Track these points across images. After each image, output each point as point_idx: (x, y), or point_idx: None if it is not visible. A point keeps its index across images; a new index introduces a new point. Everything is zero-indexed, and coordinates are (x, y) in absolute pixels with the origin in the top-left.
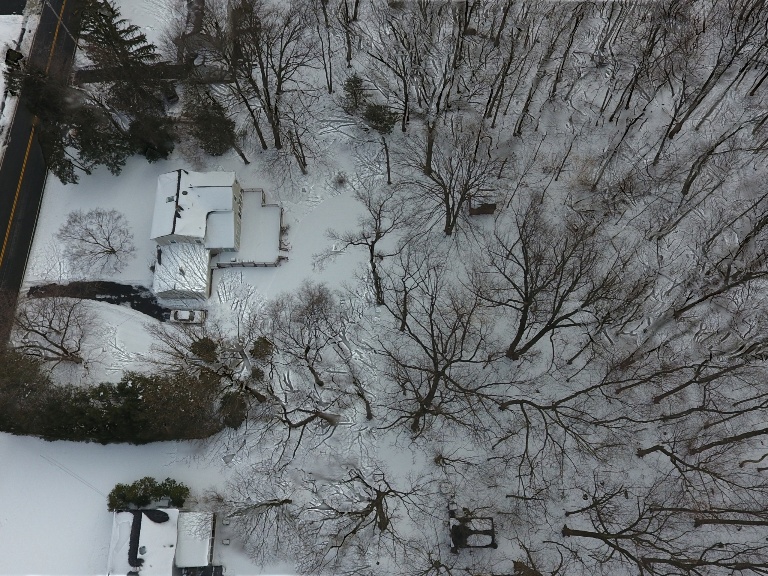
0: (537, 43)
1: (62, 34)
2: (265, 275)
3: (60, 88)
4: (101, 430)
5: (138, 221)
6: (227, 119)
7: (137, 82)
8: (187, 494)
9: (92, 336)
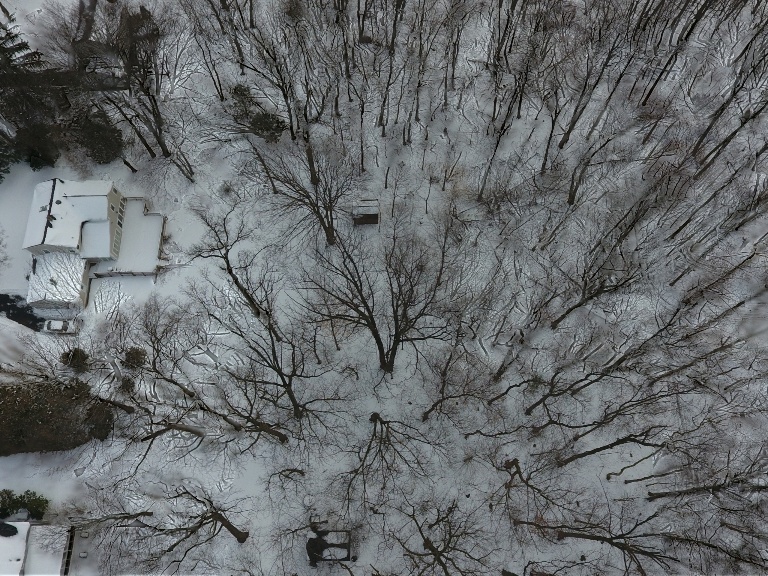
0: (432, 51)
1: None
2: (144, 285)
3: None
4: None
5: (14, 230)
6: (112, 127)
7: (23, 89)
8: (46, 506)
9: None
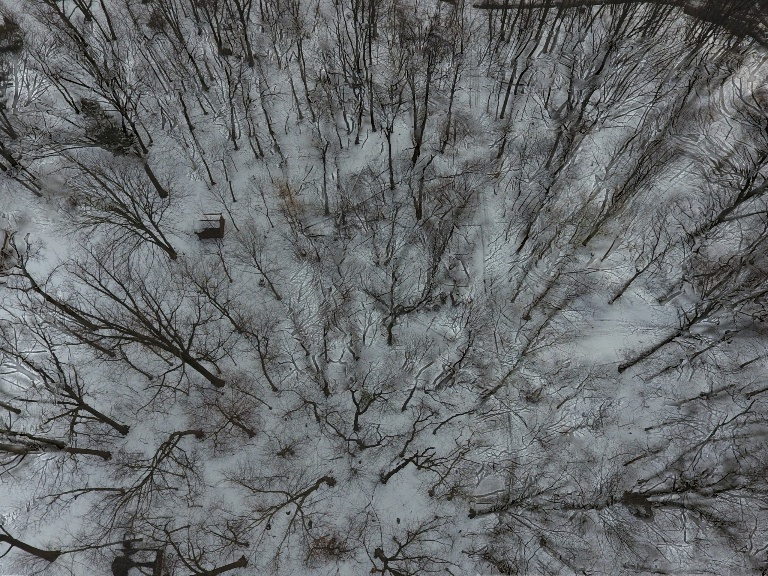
0: None
1: None
2: None
3: None
4: None
5: None
6: None
7: None
8: None
9: None
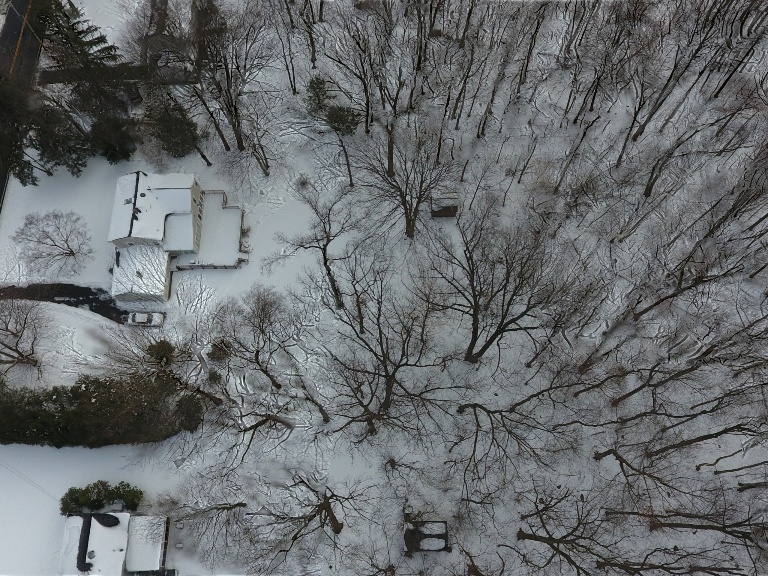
0: (502, 44)
1: (27, 34)
2: (225, 277)
3: (17, 89)
4: (53, 434)
5: (97, 223)
6: (189, 120)
7: (99, 83)
8: (141, 498)
9: (46, 339)
